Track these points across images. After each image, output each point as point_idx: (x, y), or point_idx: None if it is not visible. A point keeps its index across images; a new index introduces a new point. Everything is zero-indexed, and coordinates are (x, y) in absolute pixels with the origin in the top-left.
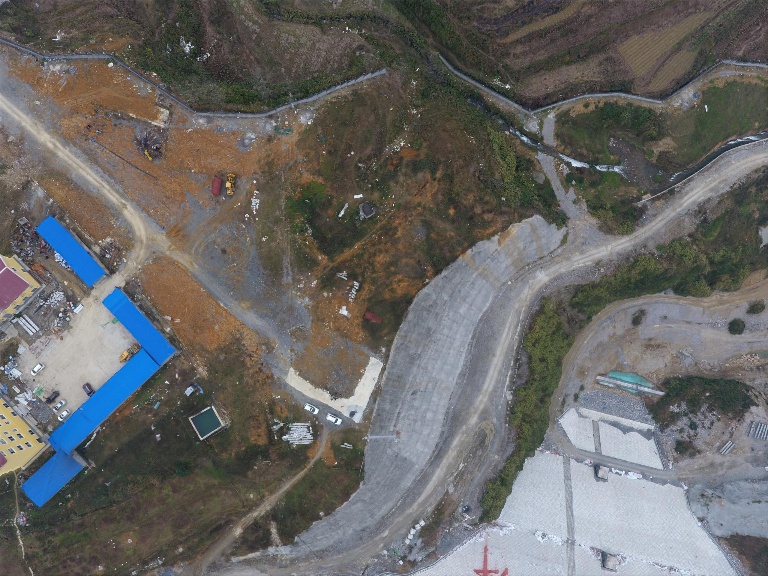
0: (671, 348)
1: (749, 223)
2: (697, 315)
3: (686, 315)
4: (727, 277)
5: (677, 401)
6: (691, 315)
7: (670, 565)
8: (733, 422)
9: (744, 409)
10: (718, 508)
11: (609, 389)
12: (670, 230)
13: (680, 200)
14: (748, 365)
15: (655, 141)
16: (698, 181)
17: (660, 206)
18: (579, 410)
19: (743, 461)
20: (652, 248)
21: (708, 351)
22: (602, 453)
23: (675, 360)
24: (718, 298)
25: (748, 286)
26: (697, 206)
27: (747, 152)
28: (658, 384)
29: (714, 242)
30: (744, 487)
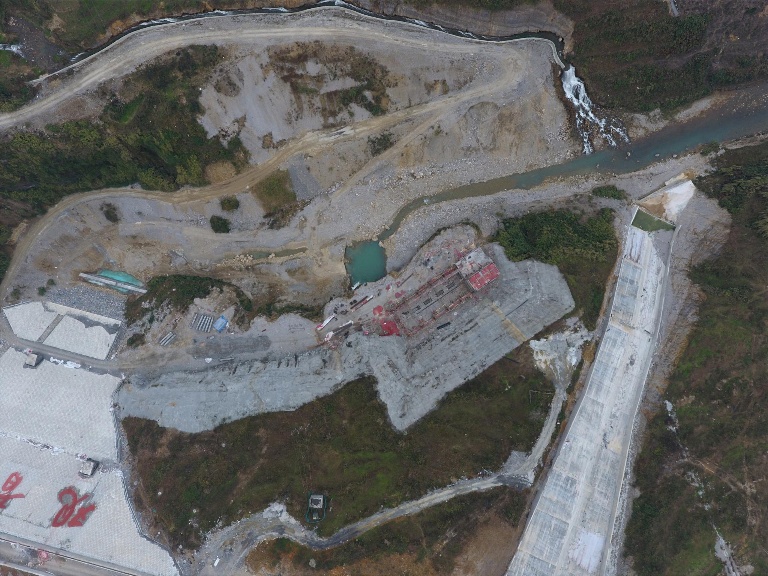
0: (161, 247)
1: (178, 109)
2: (171, 211)
3: (160, 211)
4: (181, 169)
5: (149, 297)
6: (165, 211)
7: (44, 442)
8: (177, 314)
9: (188, 301)
10: (125, 393)
11: (96, 287)
12: (66, 110)
13: (79, 80)
14: (238, 265)
15: (50, 19)
16: (101, 61)
17: (57, 86)
18: (46, 304)
19: (184, 353)
20: (39, 127)
21: (196, 250)
22: (43, 342)
23: (165, 259)
24: (189, 193)
25: (220, 181)
26: (97, 87)
27: (161, 34)
28: (145, 283)
29: (127, 126)
30: (174, 377)
